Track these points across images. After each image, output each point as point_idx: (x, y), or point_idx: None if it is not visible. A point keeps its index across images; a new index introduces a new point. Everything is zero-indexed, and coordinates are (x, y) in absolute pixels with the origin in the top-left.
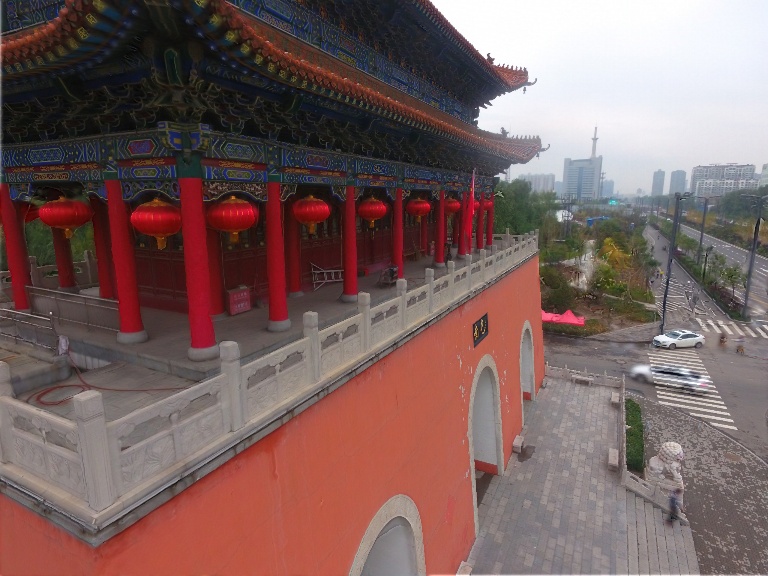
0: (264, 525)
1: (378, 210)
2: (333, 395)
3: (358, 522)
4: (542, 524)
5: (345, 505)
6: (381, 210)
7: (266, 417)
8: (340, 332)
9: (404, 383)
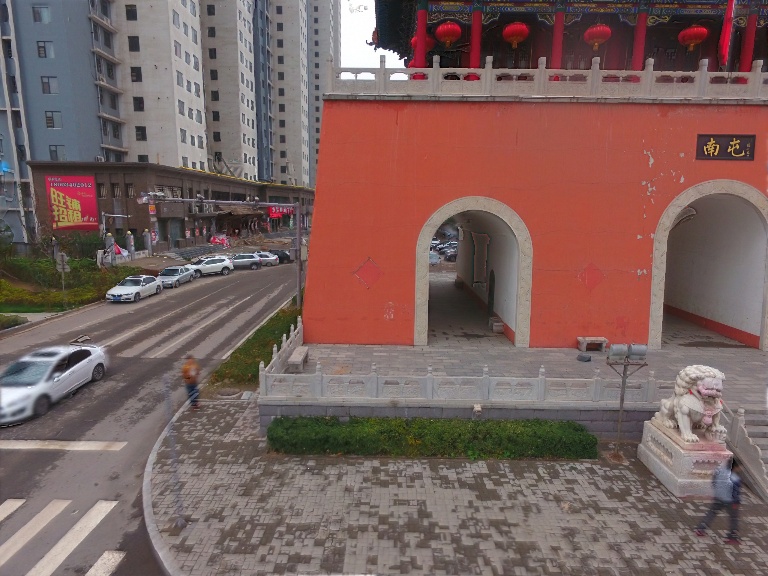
0: (387, 141)
1: (596, 31)
2: (446, 105)
3: (454, 189)
4: (743, 370)
5: (445, 172)
6: (599, 31)
7: (395, 93)
8: (461, 74)
9: (531, 133)
